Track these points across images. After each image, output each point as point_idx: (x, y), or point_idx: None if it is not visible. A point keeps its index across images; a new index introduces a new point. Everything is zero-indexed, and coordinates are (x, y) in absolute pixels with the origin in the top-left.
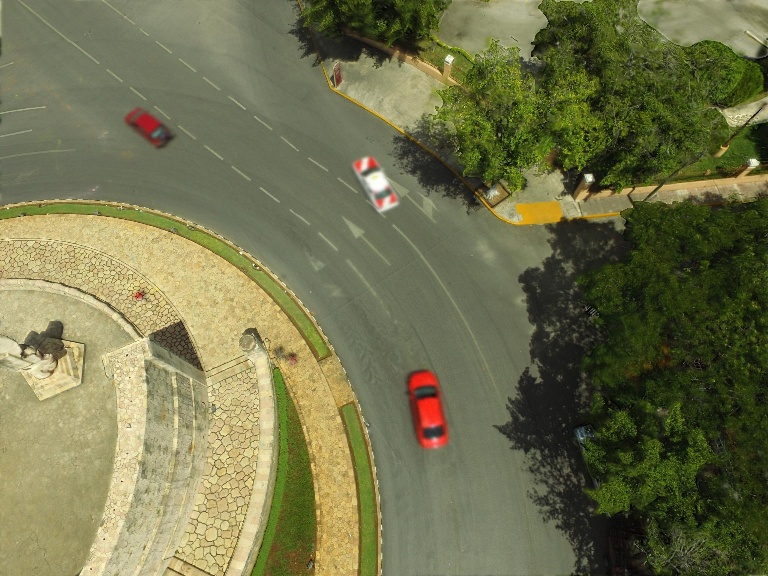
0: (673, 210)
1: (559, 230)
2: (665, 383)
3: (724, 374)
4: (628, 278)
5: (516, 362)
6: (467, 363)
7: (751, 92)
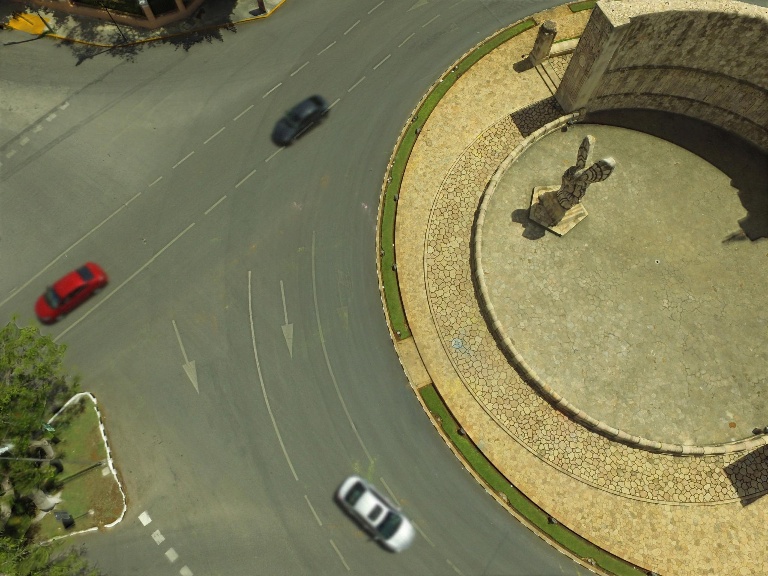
0: None
1: None
2: None
3: None
4: None
5: None
6: None
7: None
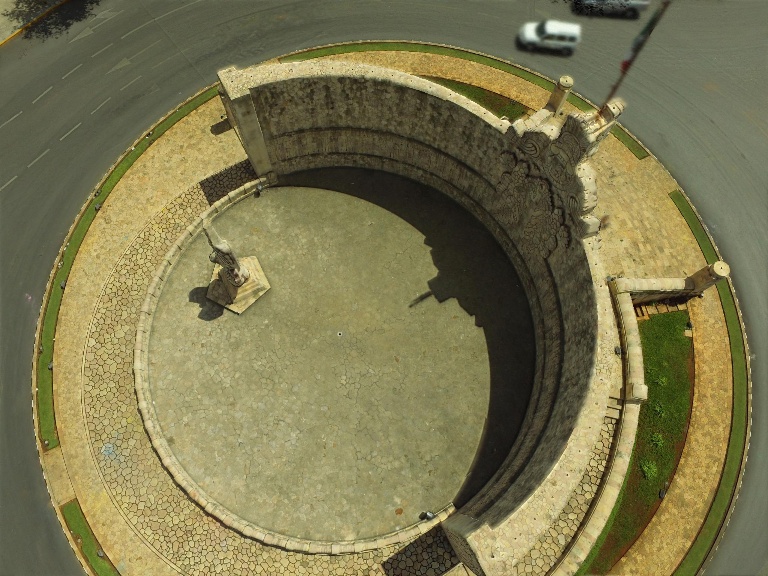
0: None
1: None
2: None
3: None
4: None
5: None
6: None
7: None
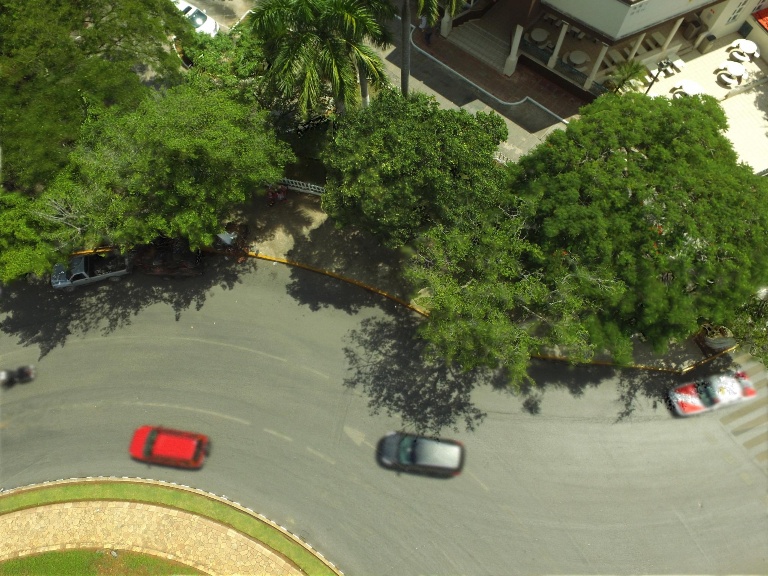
0: None
1: None
2: None
3: None
4: None
5: None
6: None
7: None
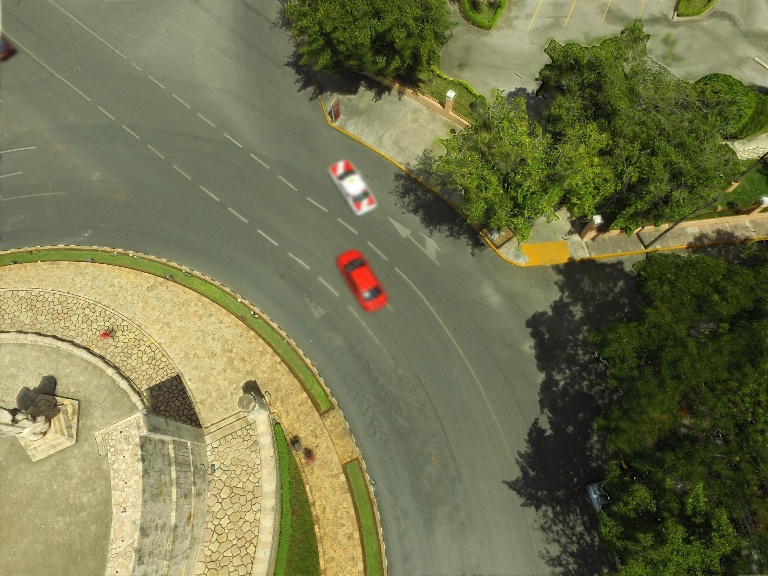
0: (688, 265)
1: (567, 271)
2: (685, 455)
3: (748, 451)
4: (643, 339)
5: (525, 413)
6: (474, 415)
7: (762, 125)
